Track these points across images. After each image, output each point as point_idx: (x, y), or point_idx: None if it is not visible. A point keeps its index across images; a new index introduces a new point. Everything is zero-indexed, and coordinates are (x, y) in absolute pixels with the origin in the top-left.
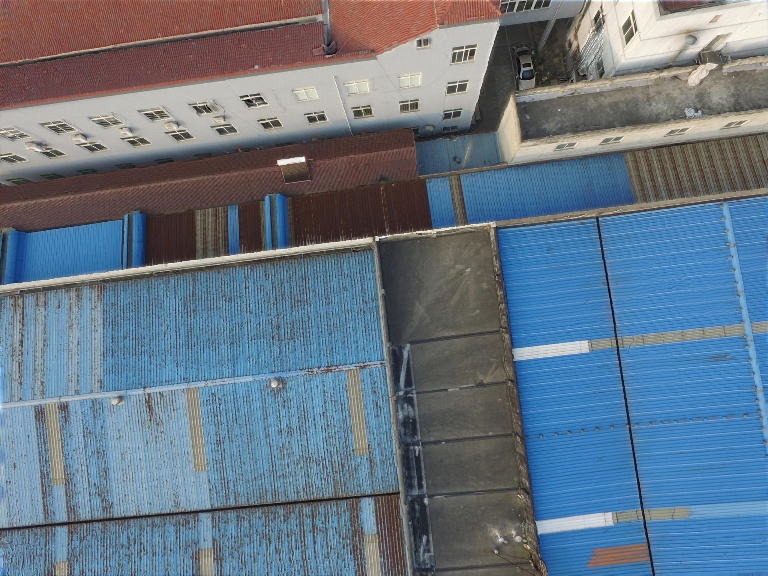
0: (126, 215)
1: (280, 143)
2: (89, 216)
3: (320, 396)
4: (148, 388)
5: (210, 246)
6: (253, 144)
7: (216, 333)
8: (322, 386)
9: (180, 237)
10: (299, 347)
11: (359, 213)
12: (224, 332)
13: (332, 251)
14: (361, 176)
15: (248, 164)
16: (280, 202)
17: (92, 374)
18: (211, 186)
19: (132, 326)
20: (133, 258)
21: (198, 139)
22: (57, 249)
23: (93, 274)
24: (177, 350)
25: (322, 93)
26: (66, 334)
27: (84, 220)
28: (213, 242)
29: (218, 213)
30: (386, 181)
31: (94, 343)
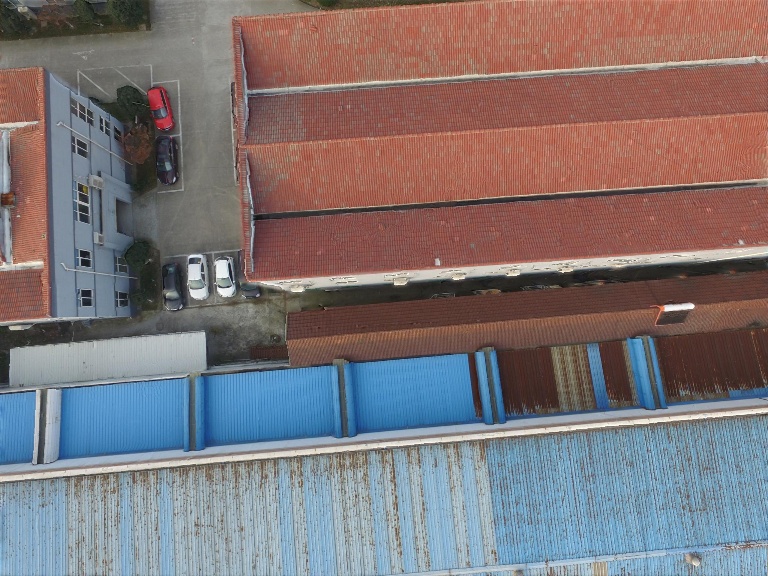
0: (482, 353)
1: (619, 268)
2: (431, 349)
3: (737, 572)
4: (551, 562)
5: (573, 390)
6: (593, 269)
7: (620, 501)
8: (740, 562)
9: (538, 377)
10: (713, 519)
11: (732, 360)
12: (629, 500)
13: (742, 415)
14: (734, 320)
15: (617, 303)
16: (654, 347)
17: (484, 544)
18: (575, 324)
19: (524, 490)
20: (498, 404)
21: (554, 269)
22: (395, 384)
23: (486, 435)
24: (578, 519)
25: (750, 251)
26: (448, 497)
27: (424, 352)
28: (576, 385)
29: (577, 352)
30: (757, 325)
31: (482, 509)
